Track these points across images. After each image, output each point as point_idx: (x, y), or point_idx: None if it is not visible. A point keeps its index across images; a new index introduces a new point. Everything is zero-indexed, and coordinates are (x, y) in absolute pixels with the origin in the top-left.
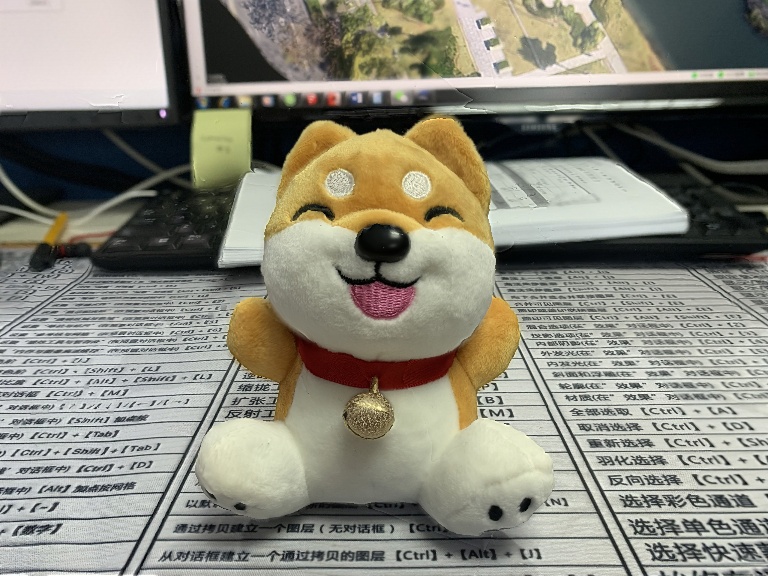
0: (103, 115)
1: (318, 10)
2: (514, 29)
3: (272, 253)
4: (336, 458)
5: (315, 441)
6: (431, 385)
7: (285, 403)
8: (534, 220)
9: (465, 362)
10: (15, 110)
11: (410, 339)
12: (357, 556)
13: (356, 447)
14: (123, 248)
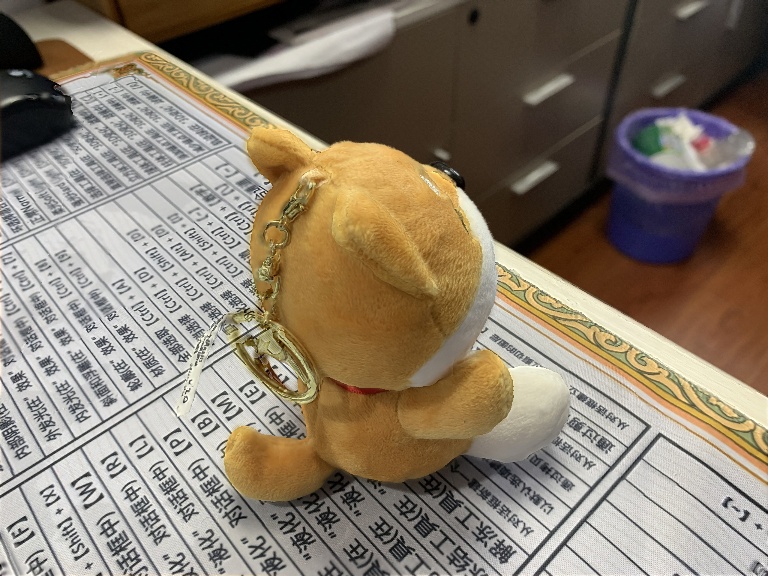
0: None
1: None
2: None
3: None
4: None
5: None
6: None
7: None
8: None
9: None
10: None
11: None
12: None
13: None
14: None
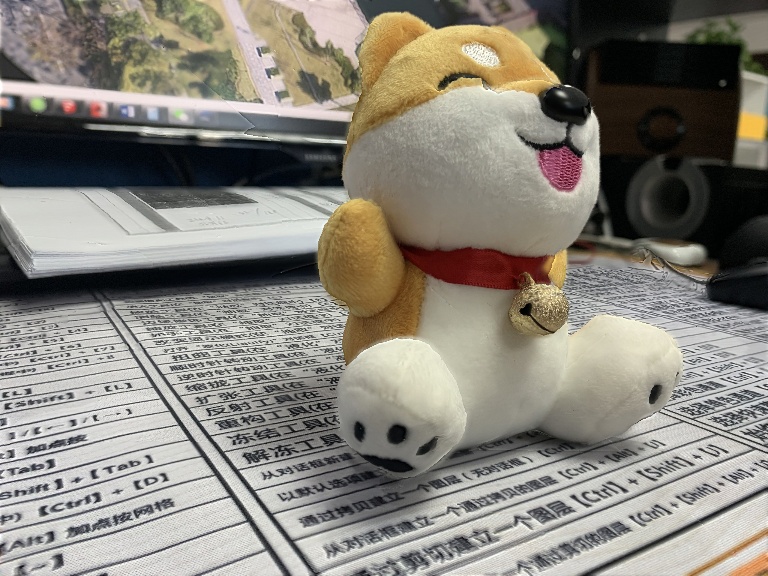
0: None
1: (76, 5)
2: (292, 62)
3: (421, 126)
4: (494, 374)
5: (469, 359)
6: None
7: (406, 328)
8: None
9: None
10: None
11: (572, 220)
12: (531, 486)
13: (513, 357)
14: None
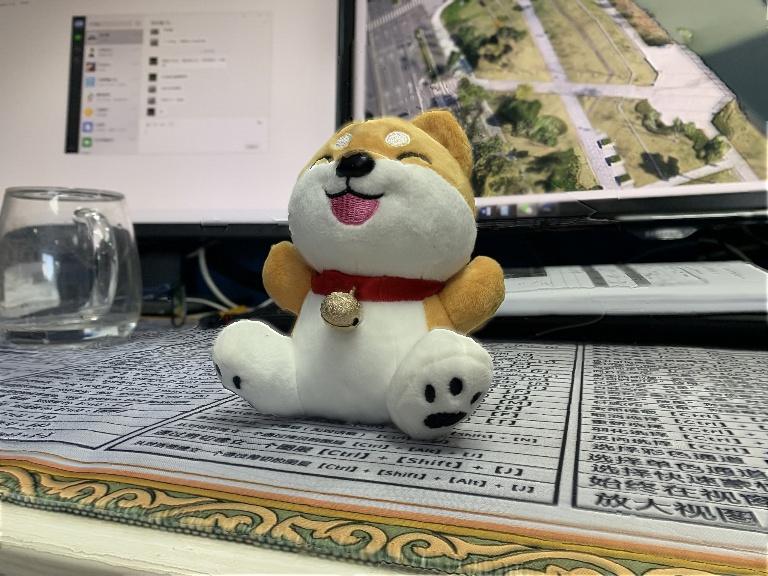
0: (281, 228)
1: None
2: (635, 146)
3: None
4: (318, 356)
5: (306, 343)
6: (403, 303)
7: None
8: (628, 293)
9: (444, 299)
10: (220, 223)
11: (375, 246)
12: (322, 440)
13: (334, 346)
14: (266, 311)
